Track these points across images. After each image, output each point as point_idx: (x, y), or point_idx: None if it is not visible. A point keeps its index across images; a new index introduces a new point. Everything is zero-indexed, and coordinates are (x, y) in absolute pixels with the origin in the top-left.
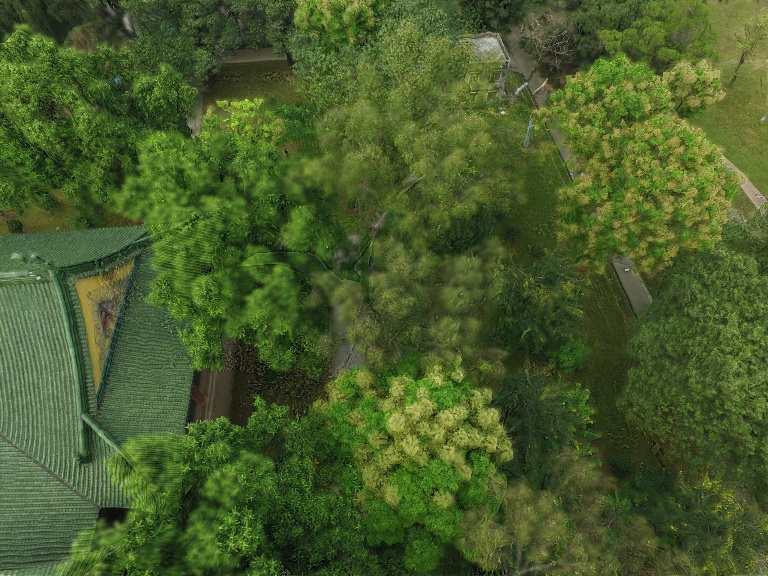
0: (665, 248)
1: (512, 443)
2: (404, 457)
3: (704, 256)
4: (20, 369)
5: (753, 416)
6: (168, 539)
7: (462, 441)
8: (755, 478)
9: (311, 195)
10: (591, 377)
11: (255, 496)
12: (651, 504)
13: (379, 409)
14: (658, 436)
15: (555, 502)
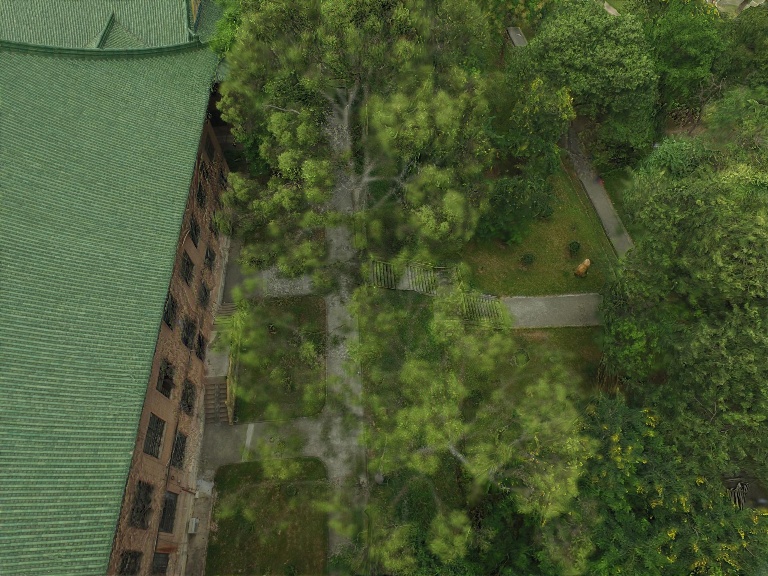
0: (536, 3)
1: (429, 82)
2: (358, 9)
3: (560, 8)
4: (154, 6)
5: (564, 58)
6: (241, 53)
7: (386, 1)
8: (578, 120)
9: (311, 11)
10: (499, 115)
11: (286, 6)
12: (516, 138)
13: (347, 4)
14: (519, 93)
15: (453, 116)
